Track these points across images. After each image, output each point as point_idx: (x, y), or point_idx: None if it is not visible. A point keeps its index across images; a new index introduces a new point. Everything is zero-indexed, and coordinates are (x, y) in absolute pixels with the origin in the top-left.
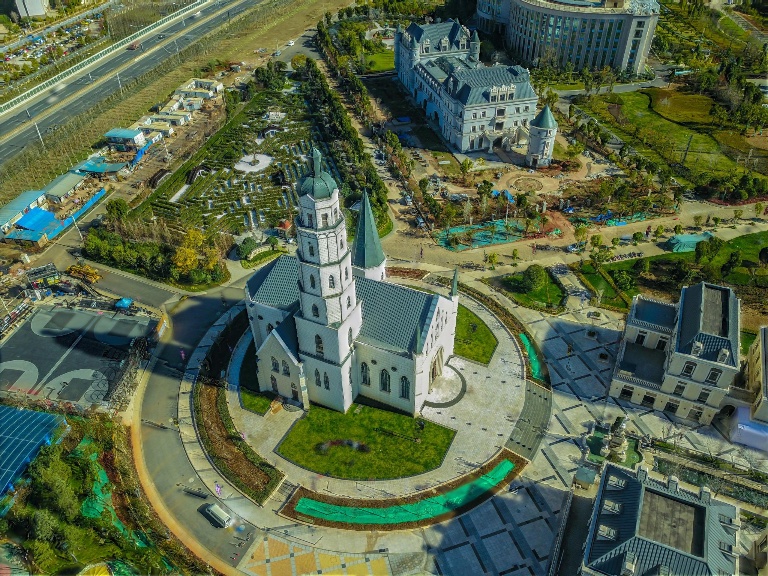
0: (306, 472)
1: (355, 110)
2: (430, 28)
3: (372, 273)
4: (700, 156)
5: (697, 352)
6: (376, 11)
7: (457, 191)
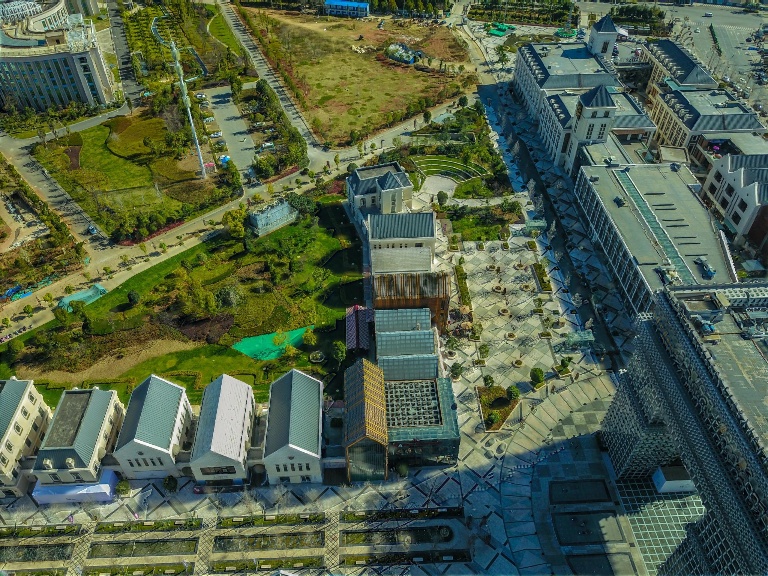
0: None
1: None
2: None
3: None
4: (130, 193)
5: None
6: None
7: None
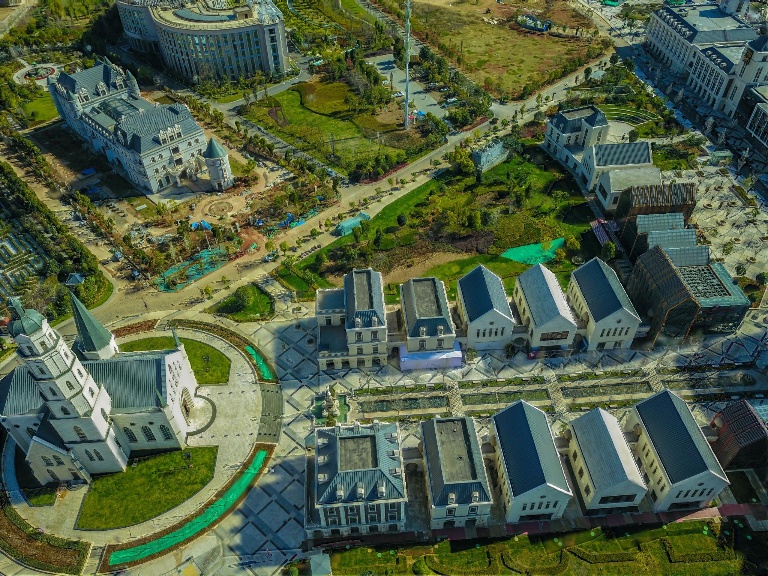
0: (108, 532)
1: (34, 172)
2: (81, 75)
3: (105, 352)
4: (347, 143)
5: (359, 325)
6: (17, 48)
7: (161, 233)
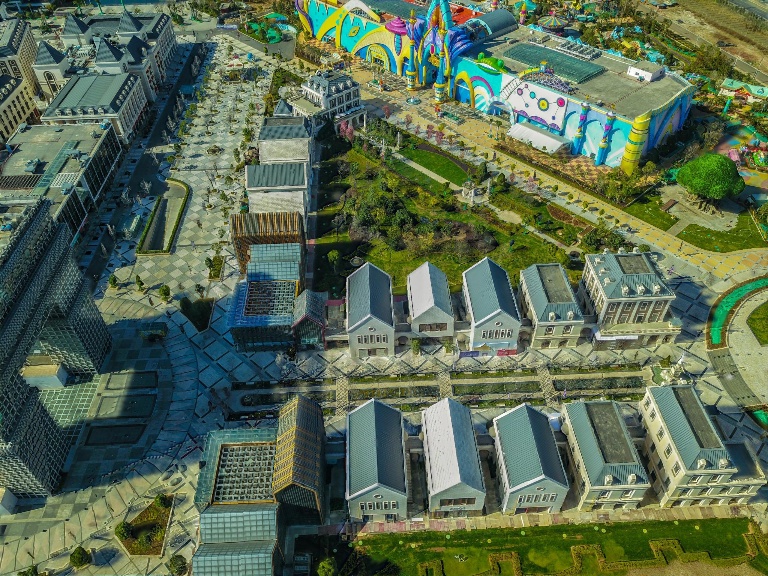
0: None
1: None
2: None
3: None
4: None
5: None
6: None
7: None
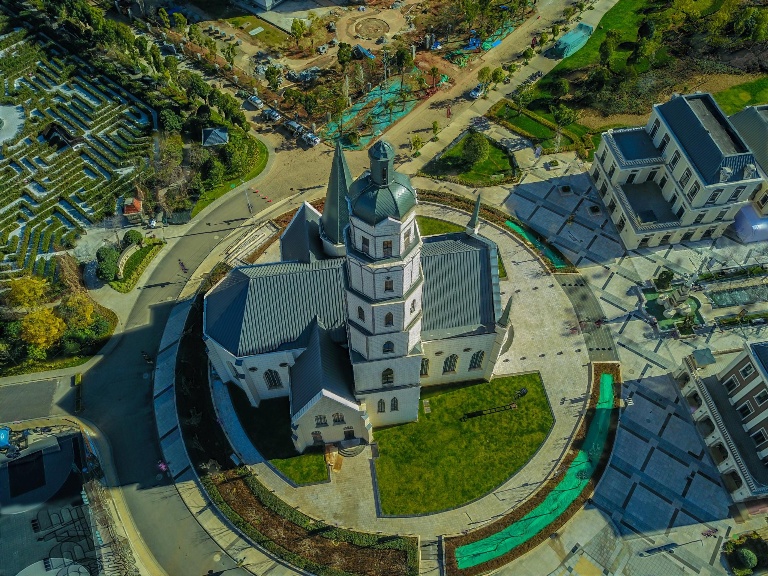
0: (435, 517)
1: None
2: None
3: None
4: None
5: (726, 178)
6: None
7: (302, 66)
